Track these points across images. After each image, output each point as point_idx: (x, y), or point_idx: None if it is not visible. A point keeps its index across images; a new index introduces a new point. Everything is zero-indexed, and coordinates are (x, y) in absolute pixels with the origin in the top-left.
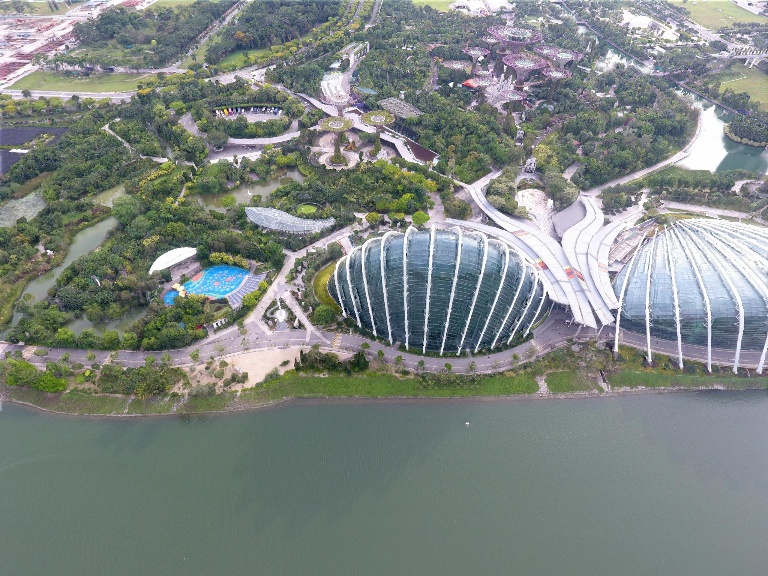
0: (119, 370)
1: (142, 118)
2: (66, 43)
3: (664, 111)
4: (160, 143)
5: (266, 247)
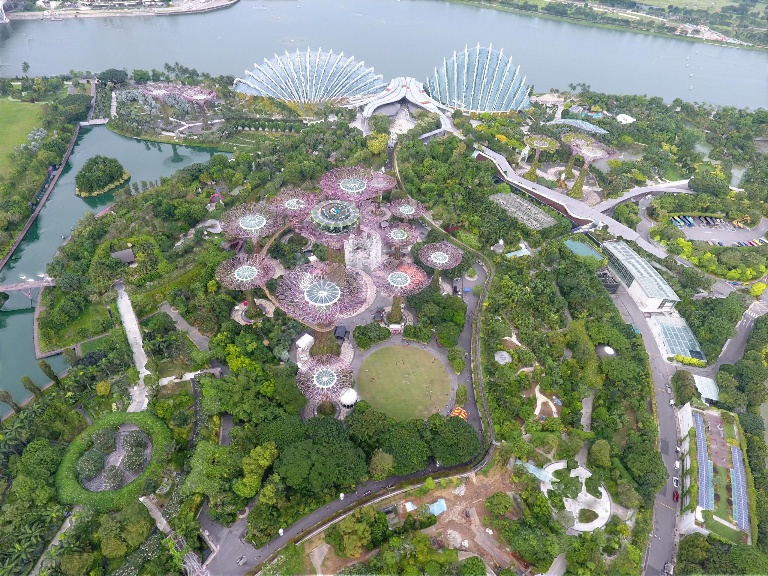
0: None
1: None
2: None
3: (197, 169)
4: None
5: None
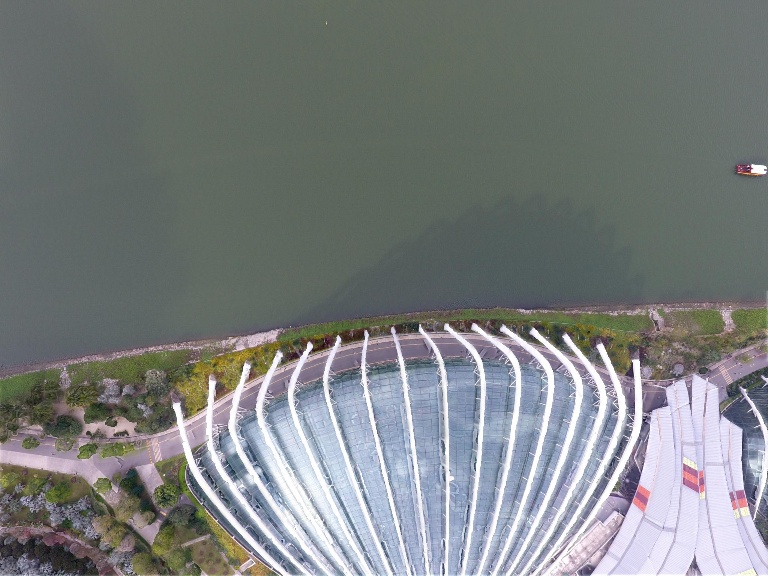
0: None
1: None
2: None
3: None
4: None
5: None
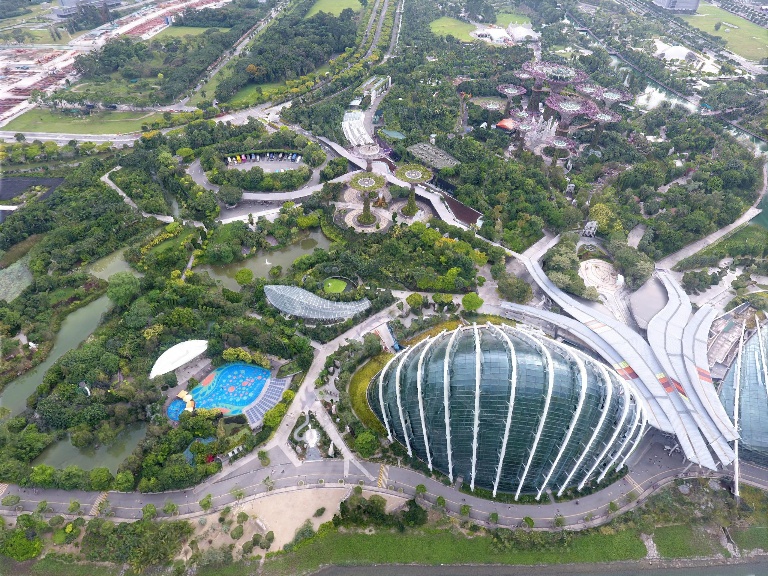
0: (109, 528)
1: (146, 166)
2: (67, 76)
3: (730, 161)
4: (165, 198)
5: (291, 342)
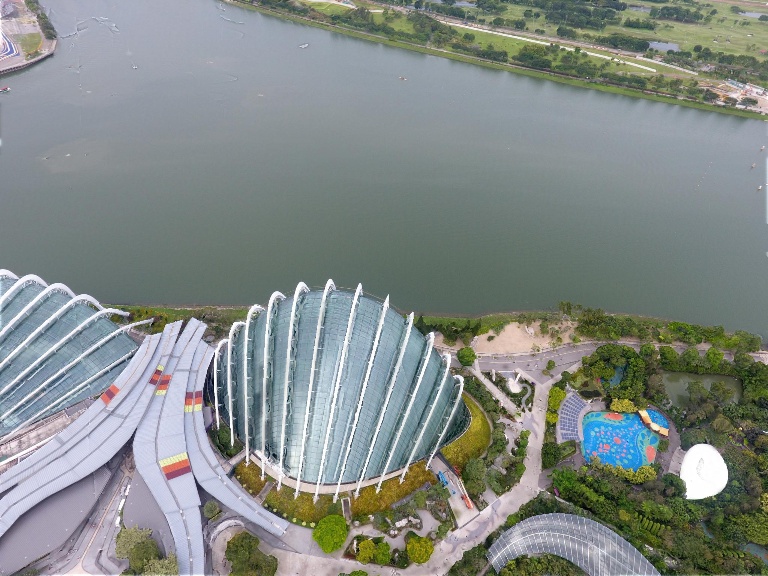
0: None
1: None
2: None
3: None
4: None
5: (579, 476)
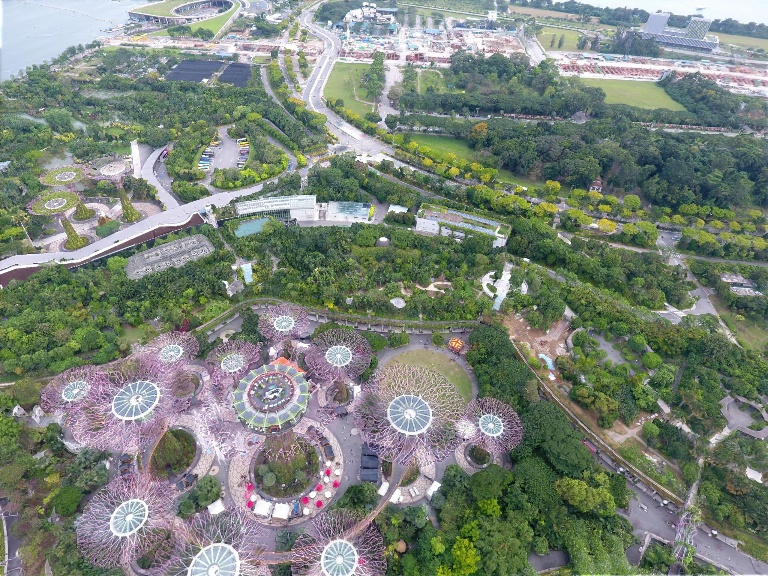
0: None
1: None
2: None
3: None
4: None
5: None
